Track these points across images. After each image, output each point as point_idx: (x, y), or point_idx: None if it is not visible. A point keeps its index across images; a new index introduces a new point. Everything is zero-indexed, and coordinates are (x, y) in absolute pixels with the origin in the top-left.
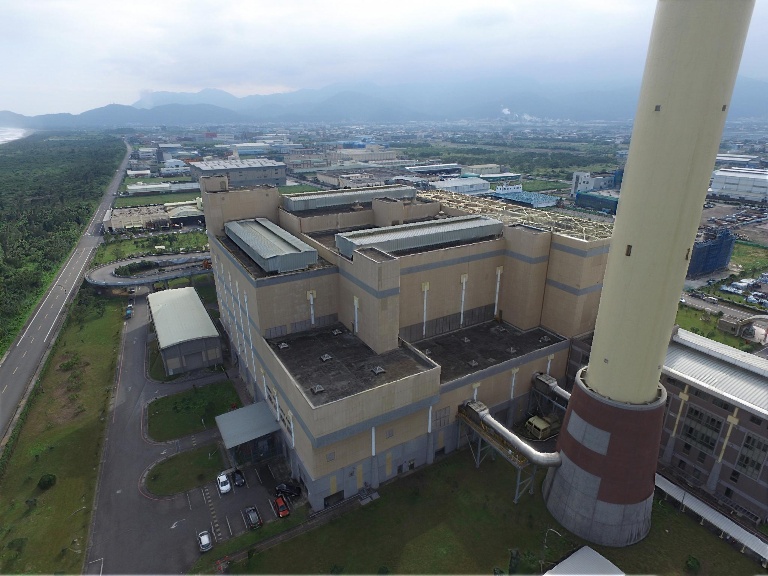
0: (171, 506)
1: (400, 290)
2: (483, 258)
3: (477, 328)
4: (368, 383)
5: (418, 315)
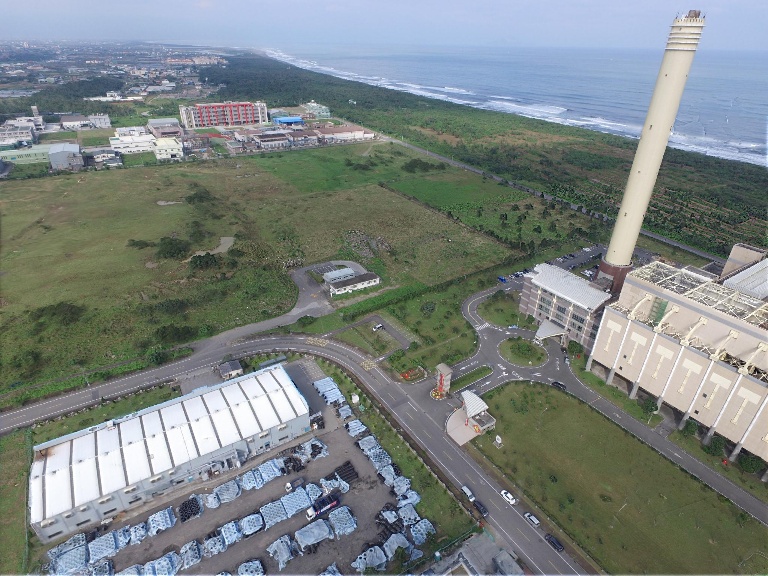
0: None
1: None
2: None
3: None
4: None
5: None
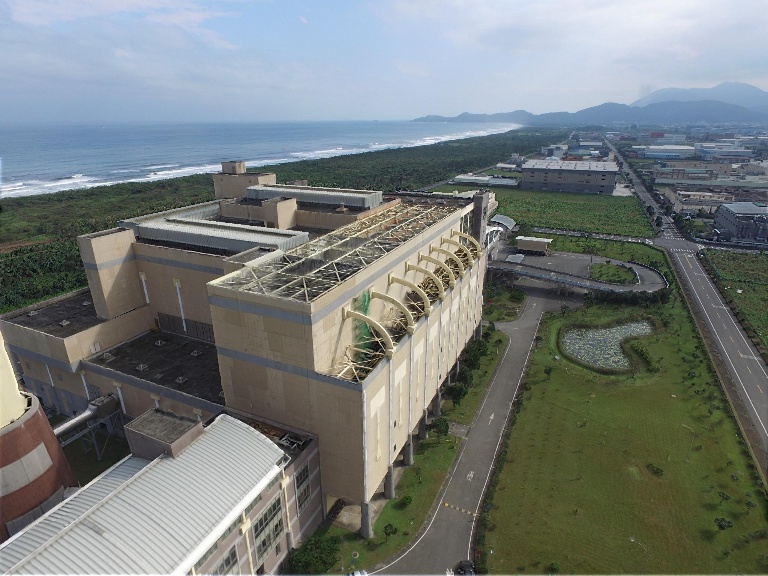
0: None
1: (157, 277)
2: None
3: None
4: (44, 326)
5: (177, 309)
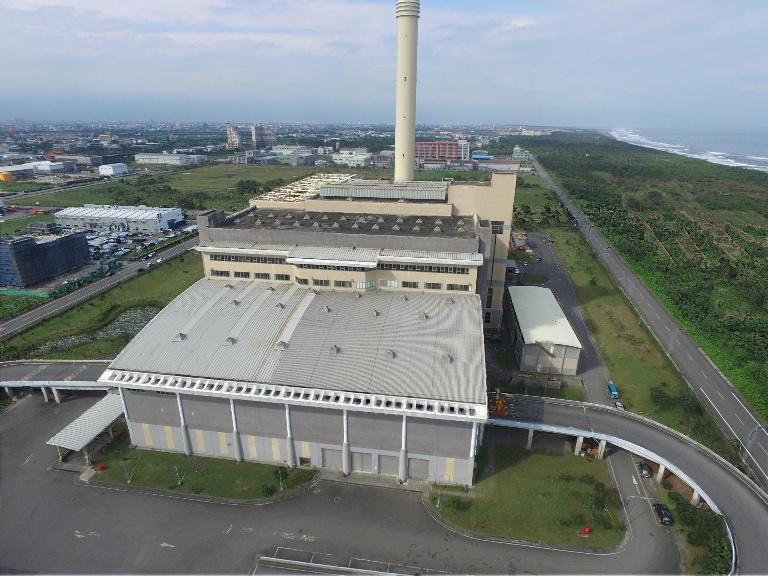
0: (537, 272)
1: None
2: None
3: None
4: None
5: None
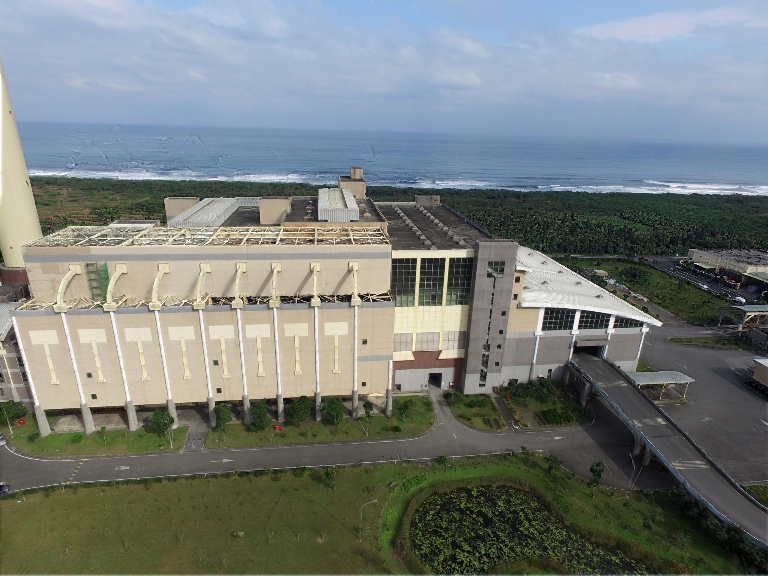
0: None
1: None
2: None
3: None
4: None
5: None
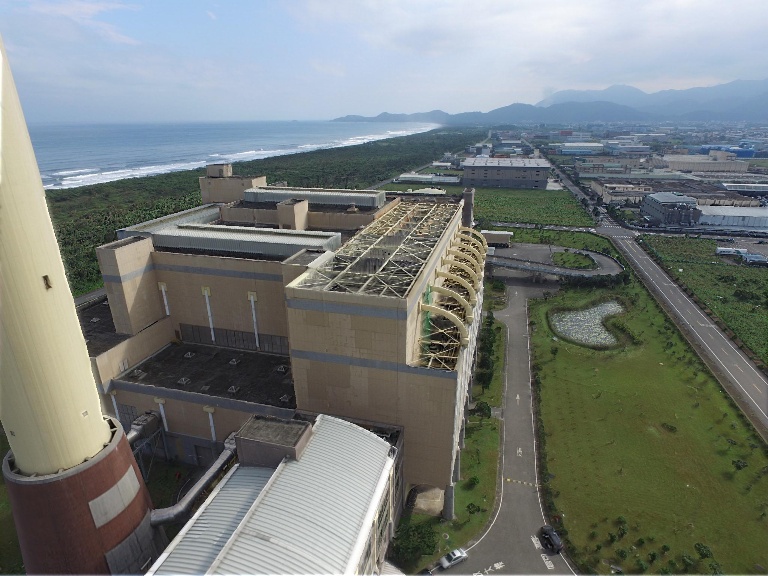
0: None
1: (180, 286)
2: (275, 280)
3: (274, 358)
4: None
5: (204, 318)
